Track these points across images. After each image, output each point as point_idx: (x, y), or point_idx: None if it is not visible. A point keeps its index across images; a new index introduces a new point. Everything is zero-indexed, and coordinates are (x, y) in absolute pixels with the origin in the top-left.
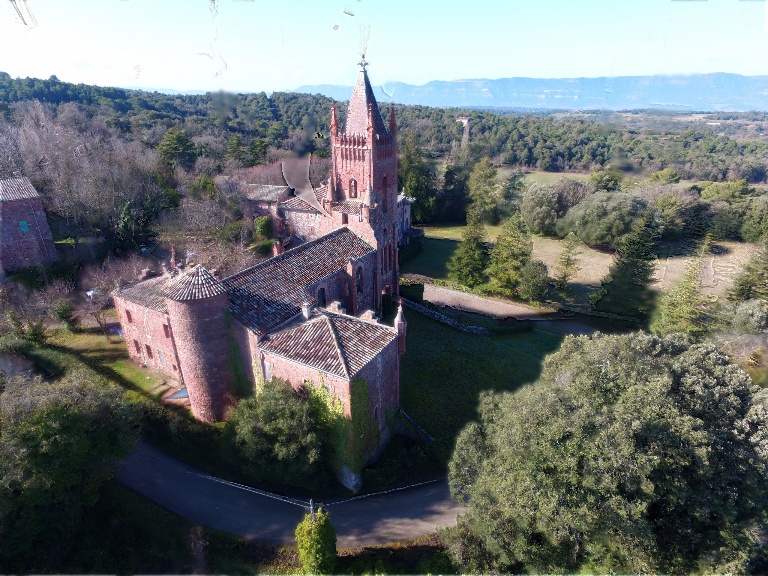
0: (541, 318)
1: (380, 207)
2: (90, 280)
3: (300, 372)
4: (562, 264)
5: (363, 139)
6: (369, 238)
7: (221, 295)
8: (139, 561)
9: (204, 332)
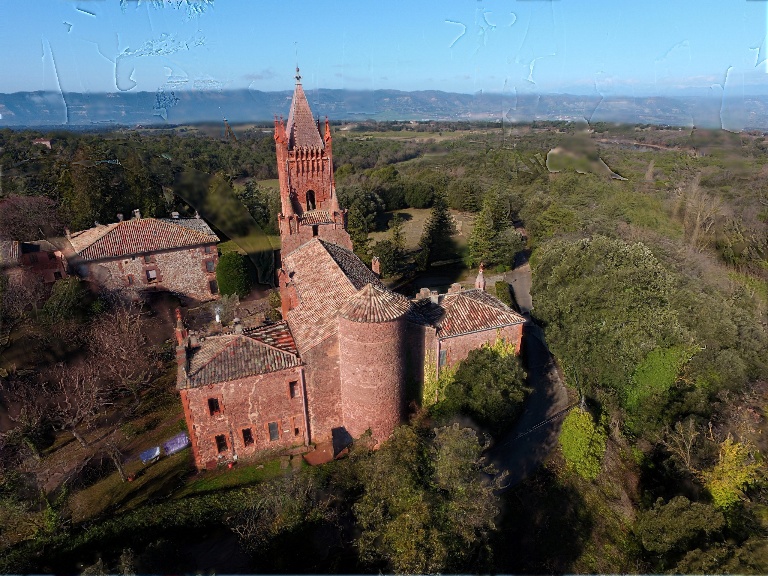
0: (401, 284)
1: None
2: None
3: (478, 340)
4: (394, 239)
5: (321, 150)
6: (344, 243)
7: None
8: (497, 556)
9: (403, 345)
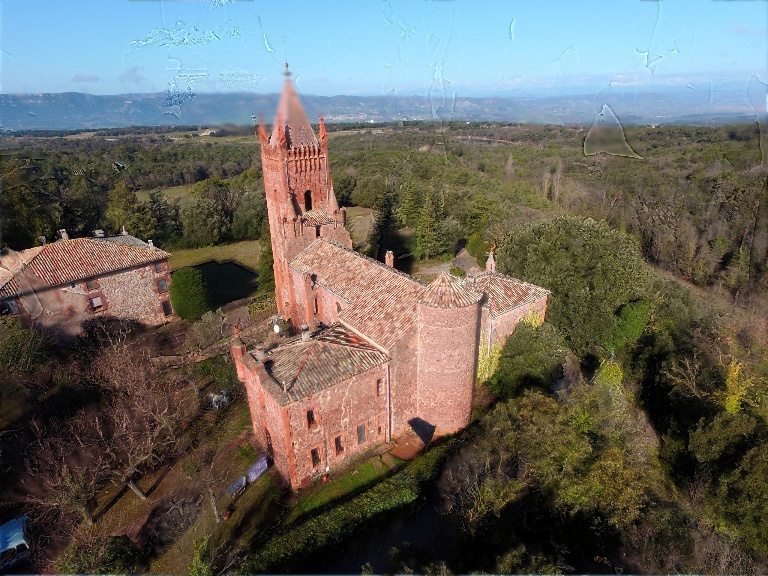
0: None
1: None
2: None
3: (517, 314)
4: None
5: (318, 148)
6: (345, 241)
7: None
8: None
9: None
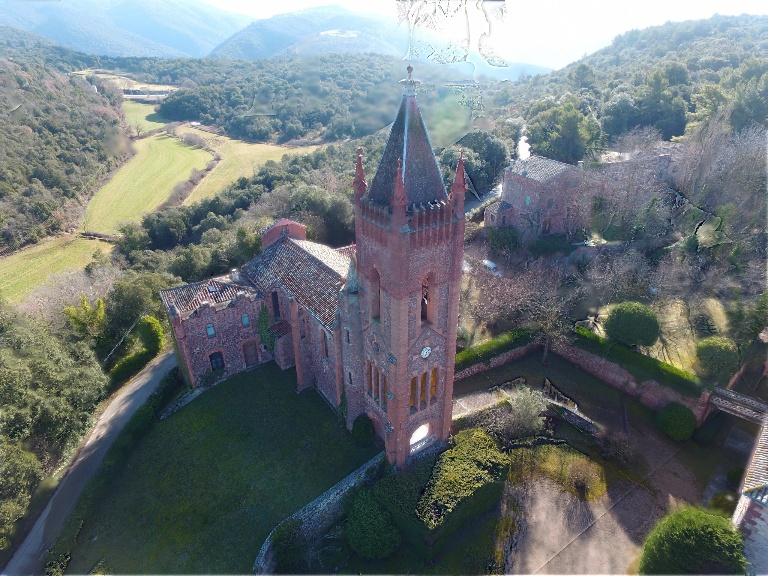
0: None
1: None
2: (523, 262)
3: None
4: None
5: None
6: None
7: (261, 237)
8: None
9: None
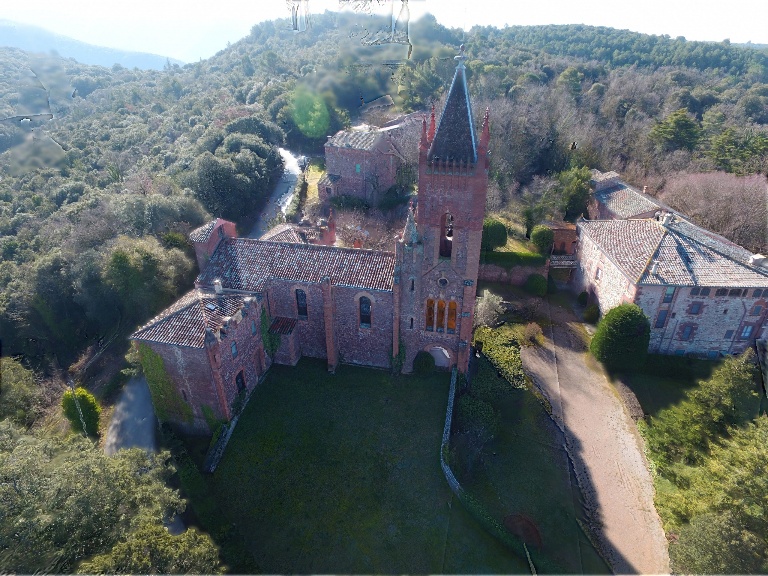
0: None
1: (411, 246)
2: None
3: None
4: None
5: None
6: None
7: (203, 244)
8: None
9: None
